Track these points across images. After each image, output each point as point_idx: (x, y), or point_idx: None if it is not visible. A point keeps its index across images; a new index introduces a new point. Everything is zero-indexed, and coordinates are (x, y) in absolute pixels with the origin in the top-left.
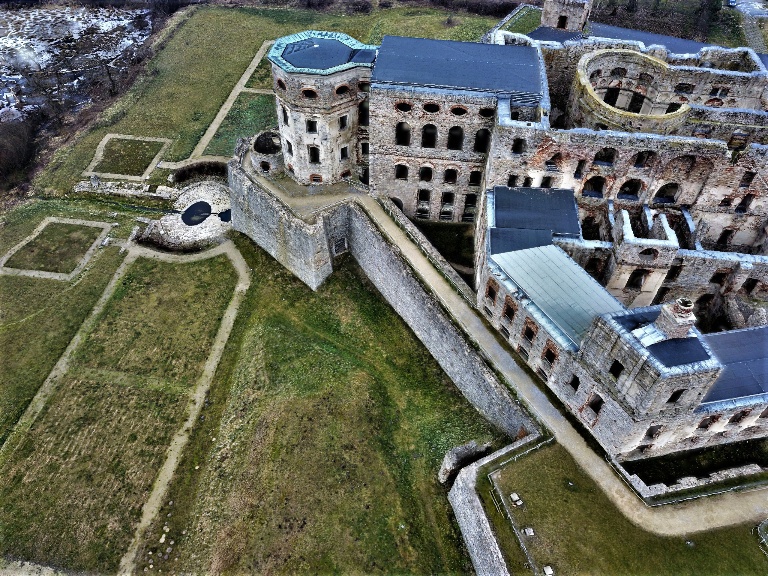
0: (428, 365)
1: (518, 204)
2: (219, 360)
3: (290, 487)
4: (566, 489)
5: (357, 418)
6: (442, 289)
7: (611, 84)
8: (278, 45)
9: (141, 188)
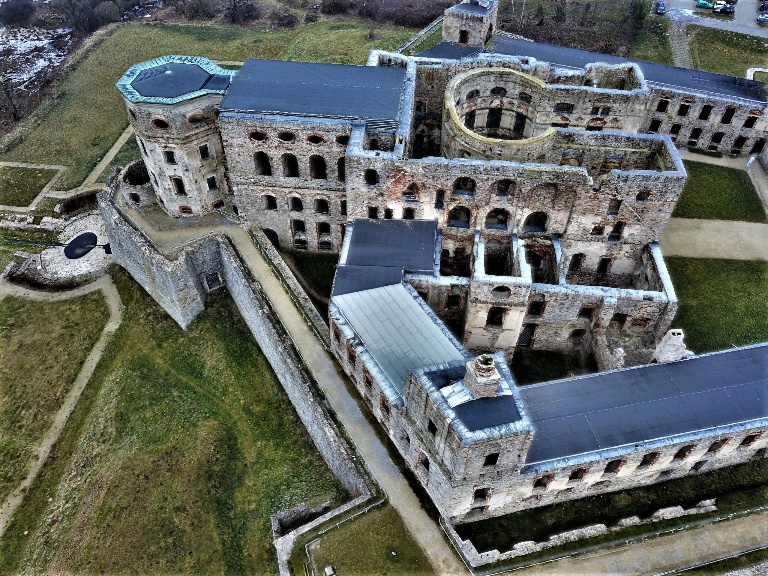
0: (285, 412)
1: (375, 238)
2: (73, 409)
3: (108, 557)
4: (388, 560)
5: (195, 475)
6: (298, 330)
7: (492, 104)
8: (130, 72)
9: (25, 220)
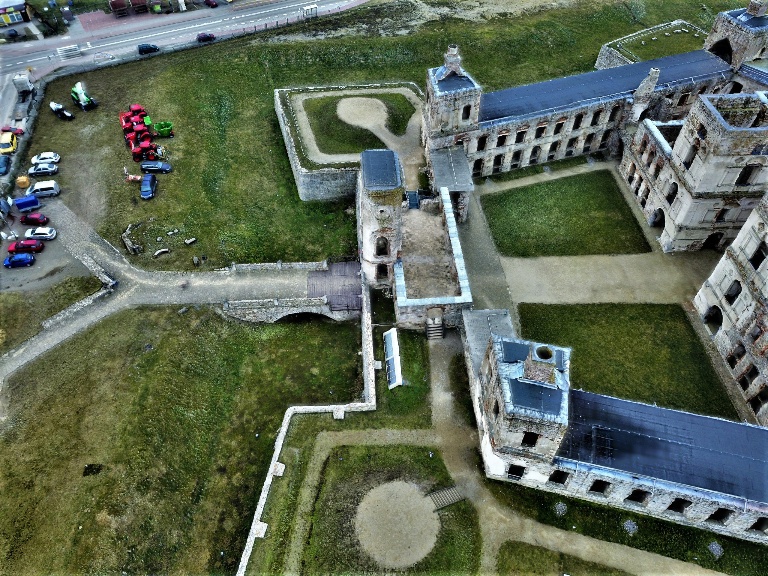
0: None
1: None
2: None
3: None
4: None
5: None
6: None
7: None
8: None
9: None
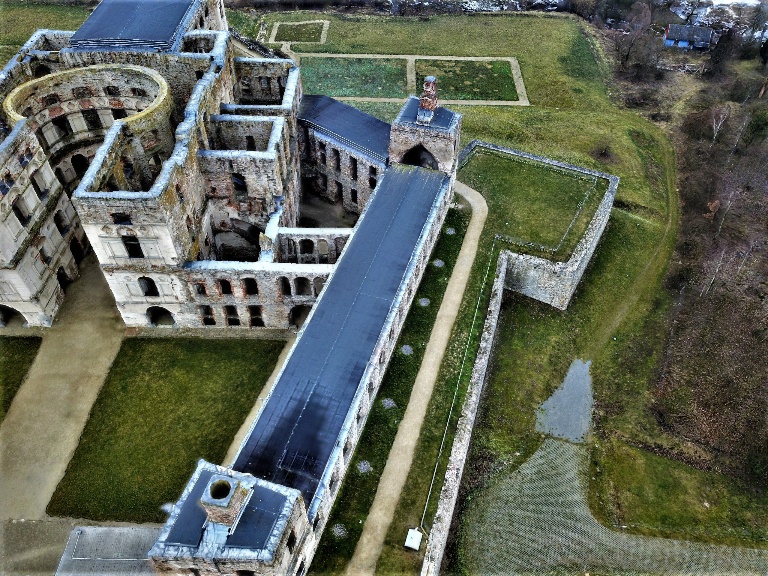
0: None
1: None
2: None
3: None
4: None
5: None
6: None
7: None
8: None
9: None
